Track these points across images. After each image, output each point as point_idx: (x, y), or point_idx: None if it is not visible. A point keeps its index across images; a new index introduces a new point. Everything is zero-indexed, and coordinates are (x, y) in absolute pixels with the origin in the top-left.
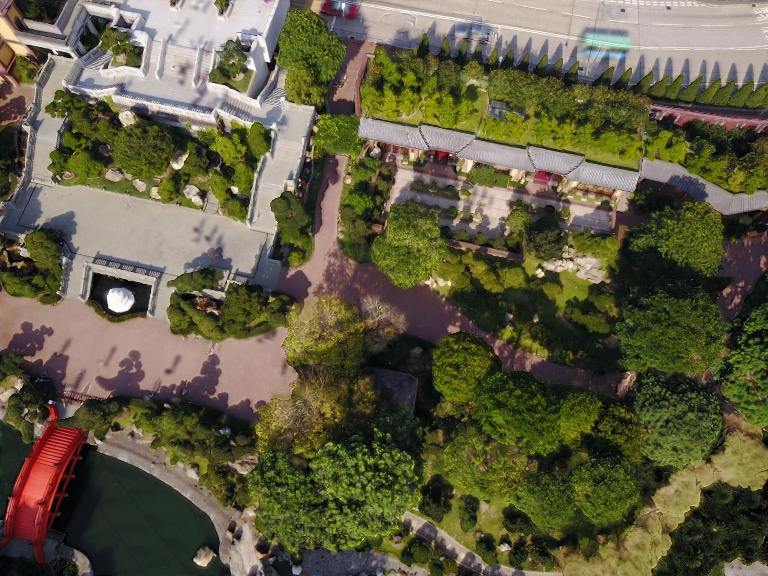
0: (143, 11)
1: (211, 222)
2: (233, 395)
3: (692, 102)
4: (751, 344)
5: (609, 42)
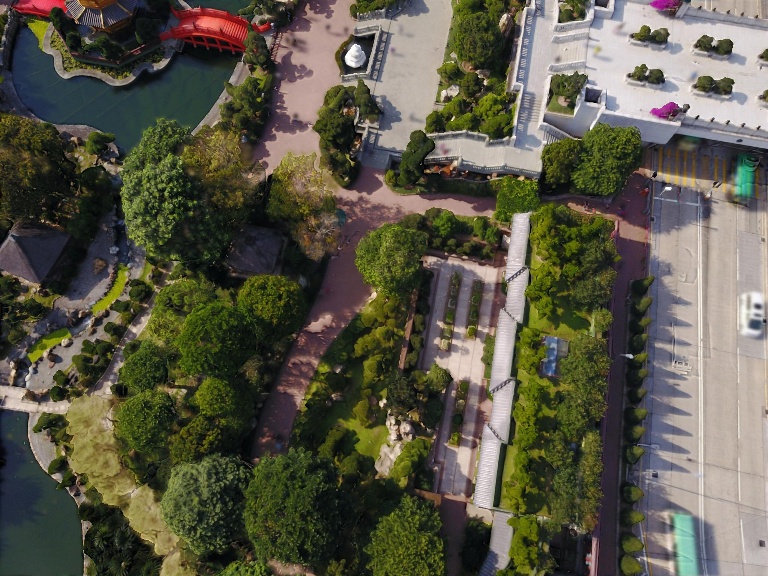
0: (622, 16)
1: (426, 111)
2: (274, 145)
3: None
4: None
5: (704, 517)
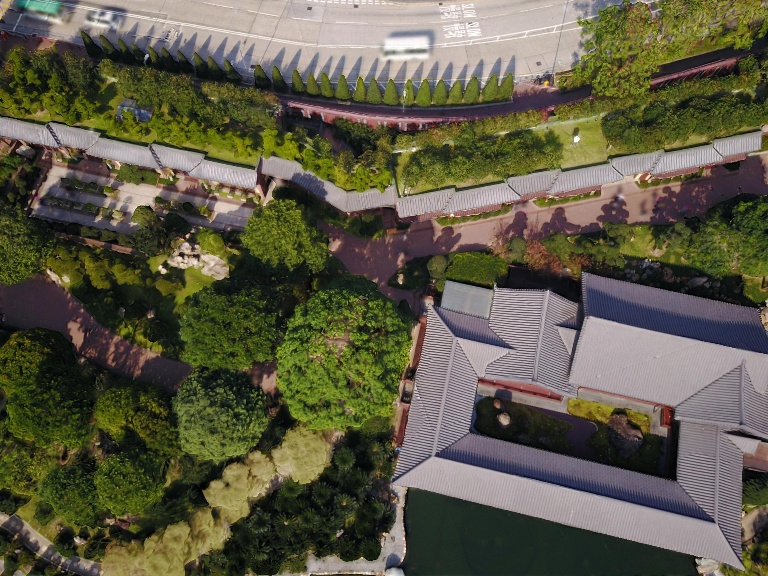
0: None
1: None
2: None
3: (350, 100)
4: (286, 340)
5: (287, 40)
